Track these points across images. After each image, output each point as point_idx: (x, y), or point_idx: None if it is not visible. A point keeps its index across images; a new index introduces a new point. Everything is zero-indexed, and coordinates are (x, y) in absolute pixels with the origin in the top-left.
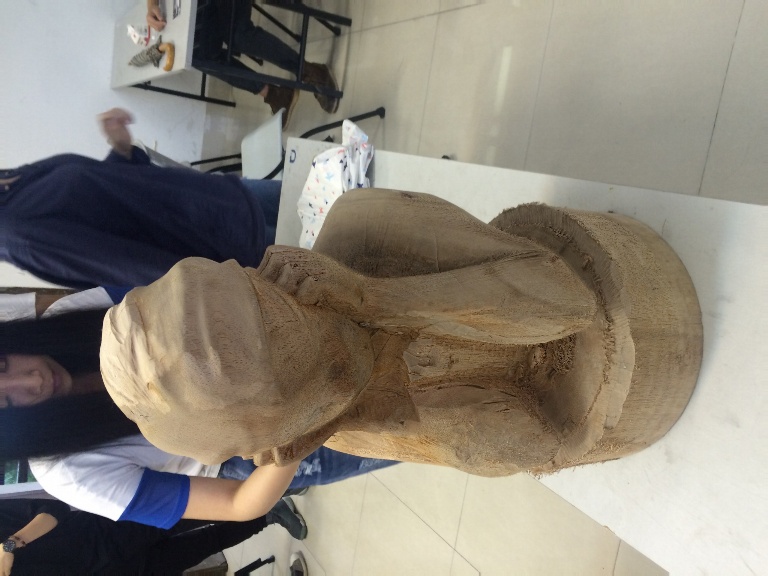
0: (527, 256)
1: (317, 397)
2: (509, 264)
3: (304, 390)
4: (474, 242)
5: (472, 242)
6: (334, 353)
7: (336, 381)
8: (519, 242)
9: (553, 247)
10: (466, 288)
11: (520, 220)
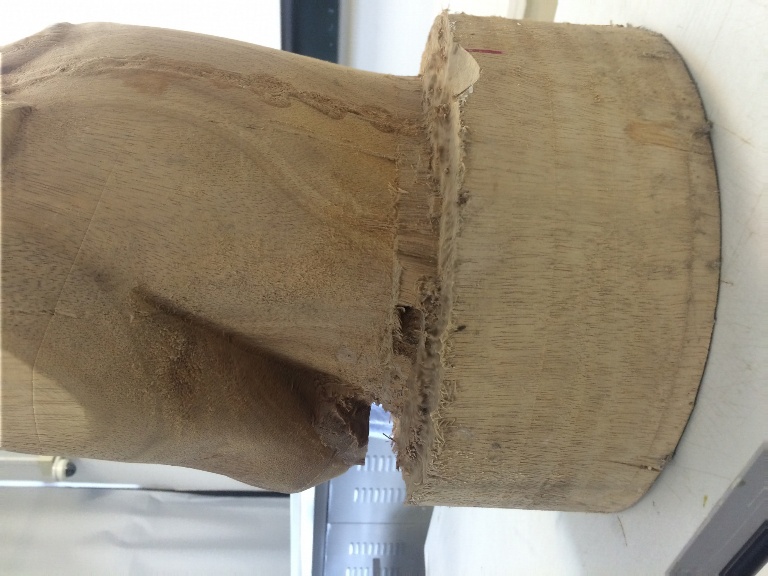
0: None
1: None
2: None
3: None
4: None
5: None
6: None
7: None
8: None
9: None
10: None
11: None
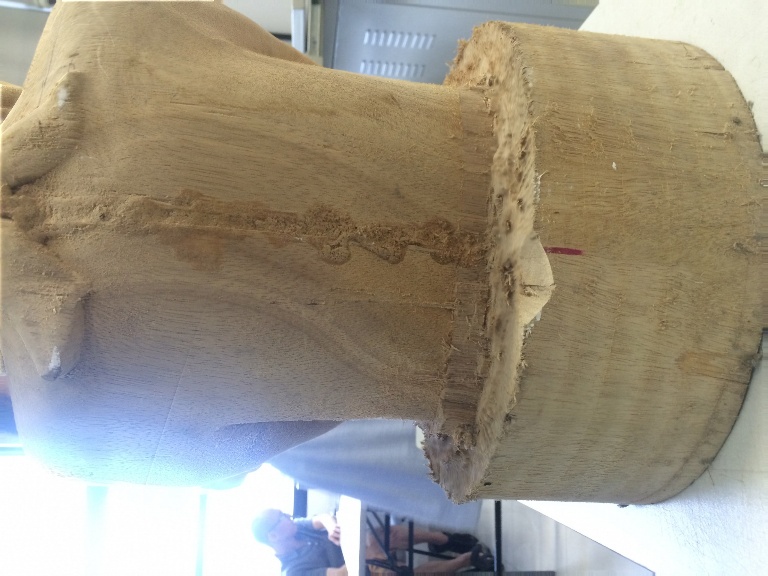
0: None
1: None
2: None
3: None
4: None
5: None
6: None
7: None
8: None
9: None
10: None
11: None
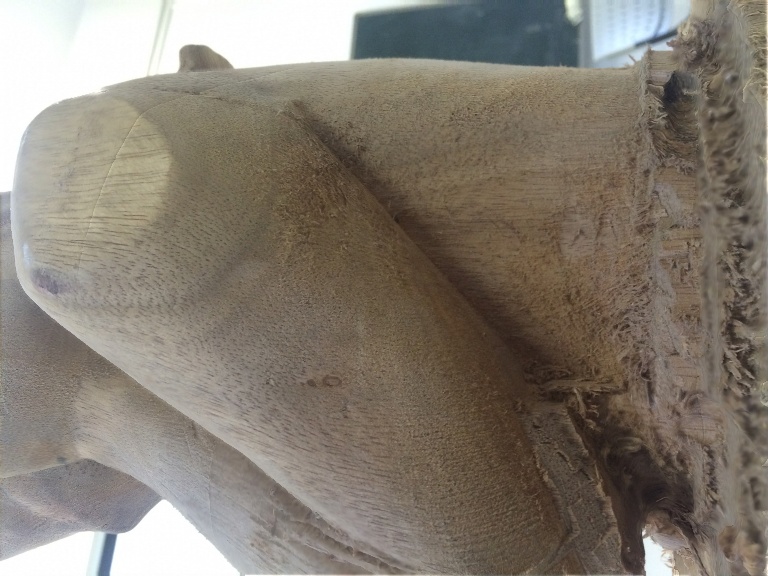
0: (365, 567)
1: (65, 537)
2: (300, 567)
3: (25, 549)
4: (239, 449)
5: (234, 447)
6: (50, 516)
7: (80, 531)
8: (357, 513)
9: (706, 367)
10: (217, 541)
11: (735, 99)
